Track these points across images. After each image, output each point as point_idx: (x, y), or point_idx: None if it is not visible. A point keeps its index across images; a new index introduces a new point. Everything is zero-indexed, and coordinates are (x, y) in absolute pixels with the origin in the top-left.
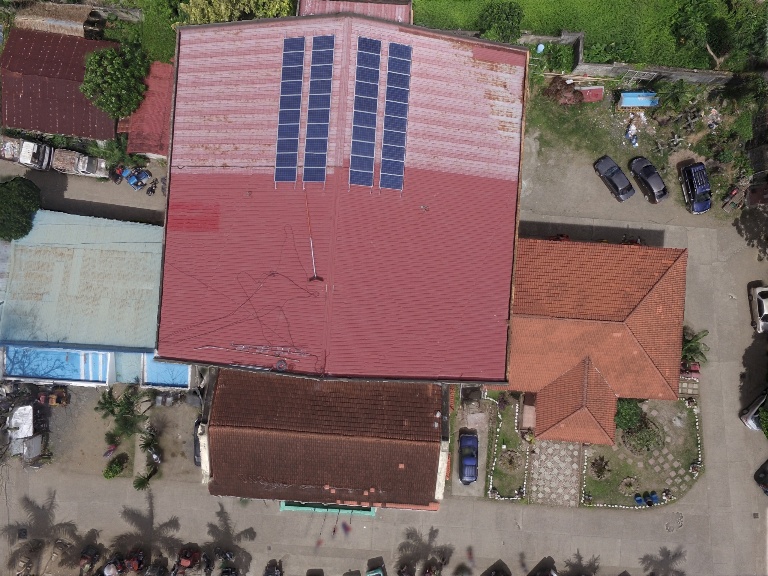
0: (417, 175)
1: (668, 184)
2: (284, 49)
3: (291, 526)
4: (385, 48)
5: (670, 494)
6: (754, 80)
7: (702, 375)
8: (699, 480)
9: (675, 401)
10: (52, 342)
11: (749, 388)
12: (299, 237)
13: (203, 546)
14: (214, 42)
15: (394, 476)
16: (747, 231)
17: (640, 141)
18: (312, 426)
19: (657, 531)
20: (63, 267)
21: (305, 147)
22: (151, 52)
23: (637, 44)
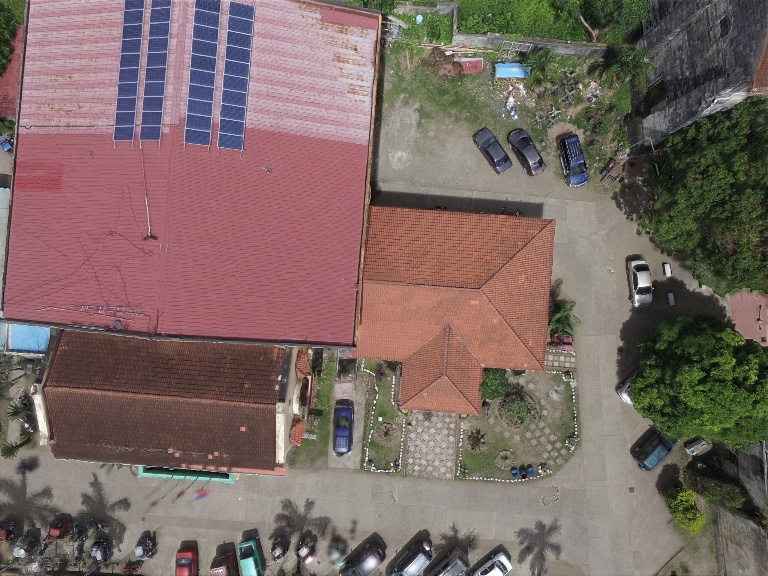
0: (259, 136)
1: (547, 157)
2: (125, 7)
3: (166, 497)
4: (226, 7)
5: (545, 467)
6: None
7: (579, 348)
8: (575, 454)
9: (552, 374)
10: None
11: (626, 362)
12: (136, 196)
13: (76, 517)
14: (61, 1)
15: (236, 440)
16: (626, 205)
17: (519, 113)
18: (150, 388)
19: (533, 505)
20: None
21: (142, 105)
22: (17, 16)
23: (515, 15)
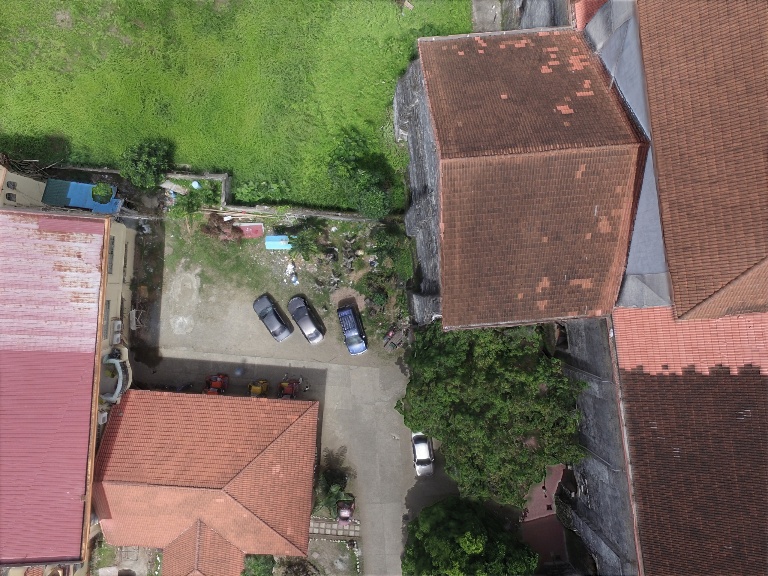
0: None
1: (330, 322)
2: None
3: None
4: None
5: None
6: (399, 224)
7: (364, 517)
8: None
9: (336, 543)
10: None
11: None
12: None
13: None
14: None
15: None
16: (411, 370)
17: (301, 278)
18: None
19: None
20: None
21: None
22: None
23: (291, 182)
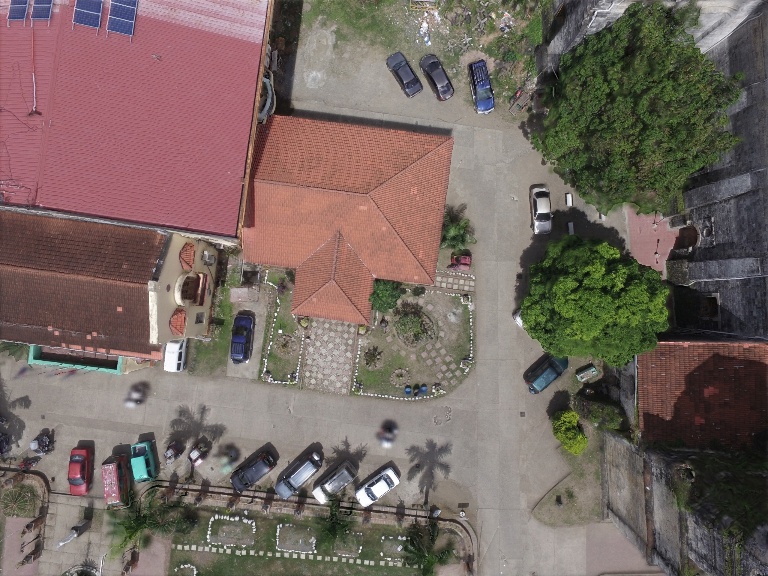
0: (151, 24)
1: (458, 84)
2: None
3: (66, 397)
4: None
5: (438, 387)
6: None
7: (479, 273)
8: (469, 376)
9: (451, 297)
10: None
11: (525, 289)
12: (25, 73)
13: None
14: None
15: (114, 320)
16: None
17: (433, 40)
18: (31, 262)
19: (425, 423)
20: None
21: None
22: None
23: None
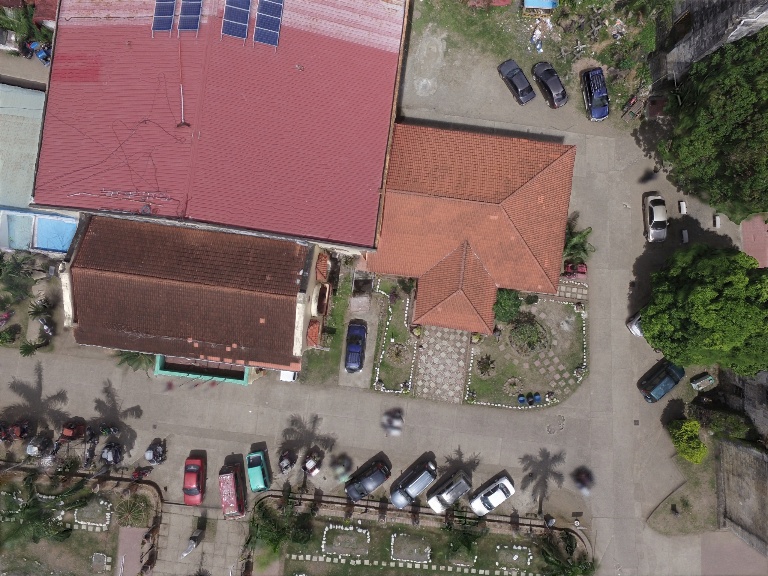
0: (294, 34)
1: (570, 91)
2: None
3: (178, 406)
4: None
5: (552, 395)
6: None
7: (592, 281)
8: (583, 384)
9: (564, 305)
10: None
11: (638, 297)
12: (171, 85)
13: (89, 421)
14: None
15: (255, 331)
16: (645, 142)
17: (545, 47)
18: (175, 274)
19: (538, 432)
20: None
21: None
22: None
23: None
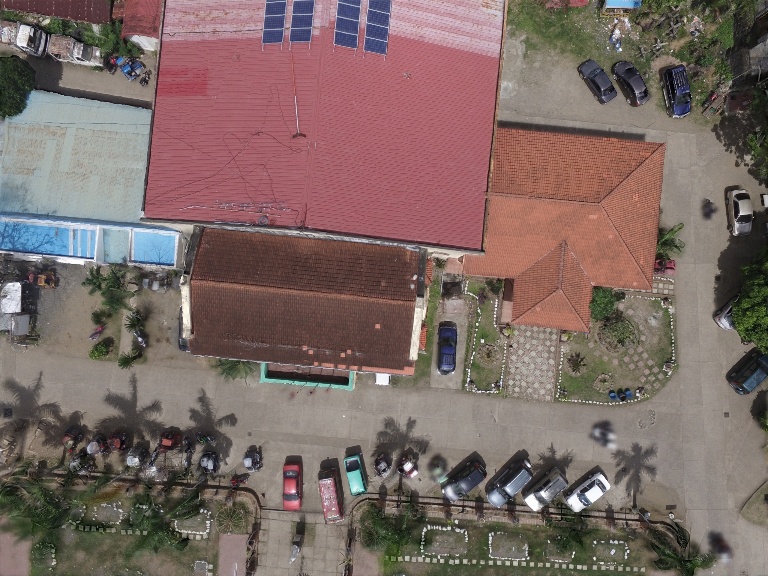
0: (401, 43)
1: (650, 89)
2: None
3: (272, 413)
4: None
5: (643, 391)
6: None
7: (678, 276)
8: (672, 379)
9: (651, 301)
10: (42, 214)
11: (723, 290)
12: (284, 96)
13: (185, 430)
14: None
15: (370, 337)
16: (726, 137)
17: (624, 46)
18: (292, 283)
19: (630, 427)
20: (55, 145)
21: (292, 9)
22: None
23: None
